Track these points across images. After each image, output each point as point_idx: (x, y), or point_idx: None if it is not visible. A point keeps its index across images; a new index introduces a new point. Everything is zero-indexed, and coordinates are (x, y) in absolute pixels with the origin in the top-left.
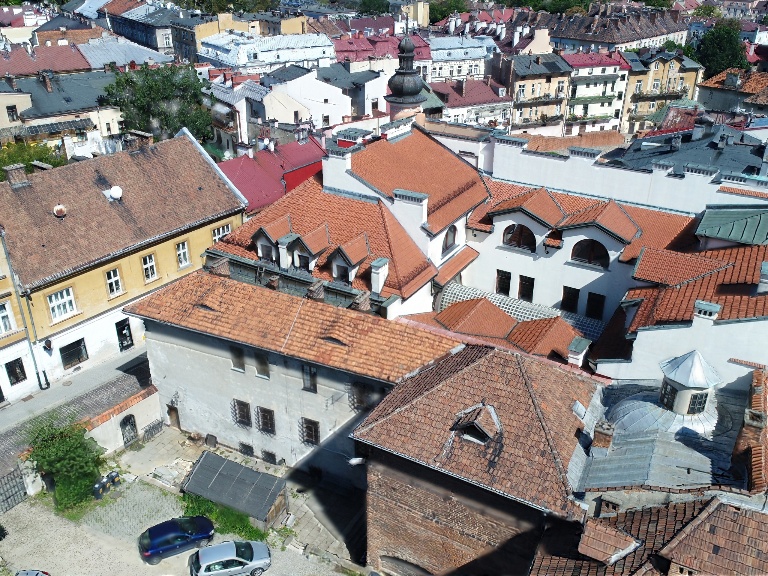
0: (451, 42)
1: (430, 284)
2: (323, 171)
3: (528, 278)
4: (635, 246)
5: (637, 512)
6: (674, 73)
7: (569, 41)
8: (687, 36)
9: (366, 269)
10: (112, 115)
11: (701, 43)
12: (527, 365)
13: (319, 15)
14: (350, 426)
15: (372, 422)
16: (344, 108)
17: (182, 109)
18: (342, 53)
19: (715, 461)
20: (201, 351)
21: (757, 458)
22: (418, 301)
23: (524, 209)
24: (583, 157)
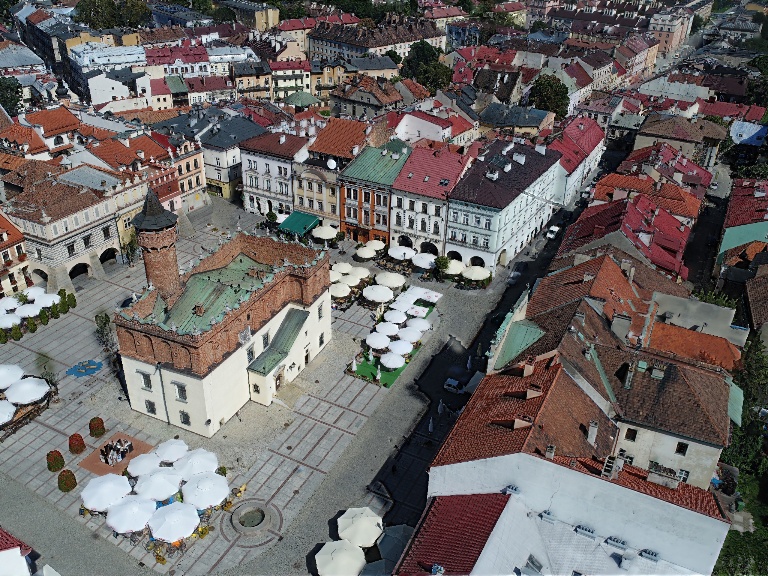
0: (225, 51)
1: (48, 152)
2: (19, 119)
3: None
4: None
5: None
6: (341, 74)
7: (345, 44)
8: (446, 40)
9: None
10: None
11: None
12: (37, 163)
13: (184, 21)
14: None
15: (3, 176)
16: (125, 92)
17: (5, 96)
18: (151, 58)
19: None
20: None
21: None
22: (42, 157)
23: (78, 131)
24: (99, 116)
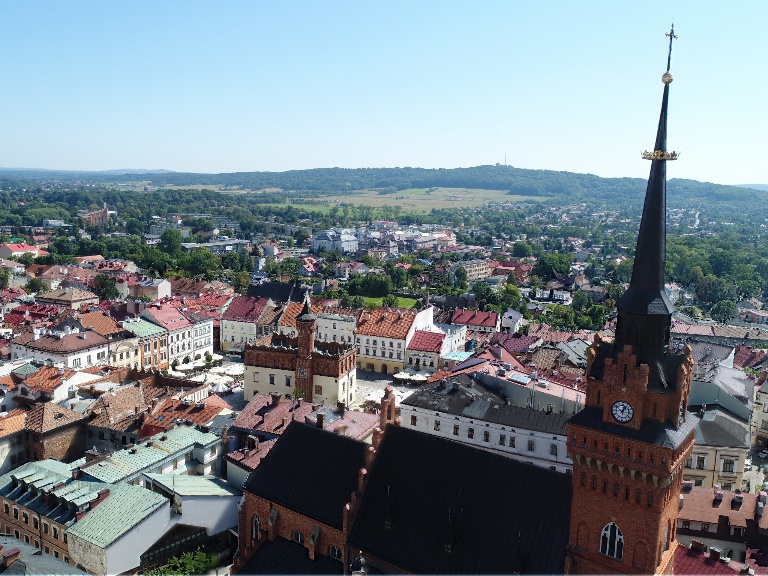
0: None
1: None
2: None
3: None
4: (8, 387)
5: (93, 408)
6: None
7: None
8: None
9: None
10: None
11: None
12: None
13: None
14: None
15: None
16: None
17: None
18: None
19: (90, 398)
20: None
21: (99, 390)
22: None
23: None
24: None
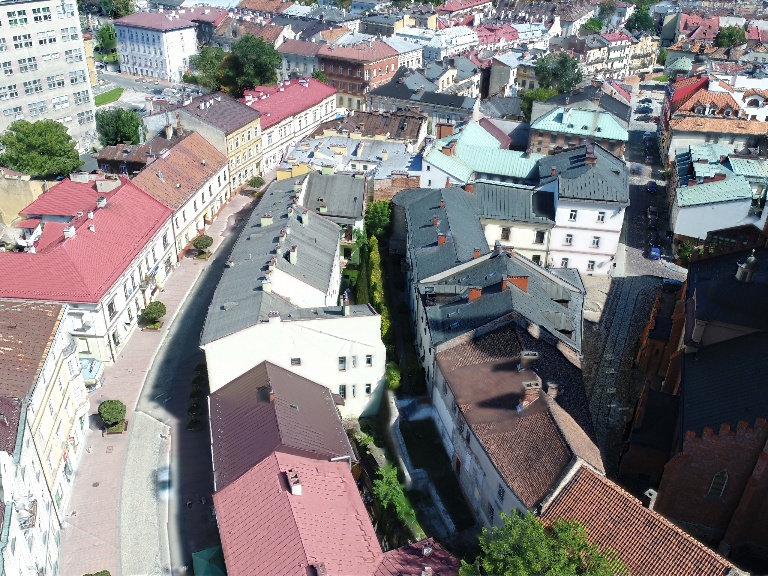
0: (523, 28)
1: None
2: (710, 86)
3: (755, 115)
4: None
5: None
6: (649, 42)
7: None
8: (594, 13)
9: (733, 112)
10: (476, 78)
11: (628, 21)
12: None
13: (369, 5)
14: (741, 152)
15: None
16: None
17: None
18: (480, 37)
19: None
20: (695, 139)
21: None
22: None
23: (758, 94)
24: (767, 78)
